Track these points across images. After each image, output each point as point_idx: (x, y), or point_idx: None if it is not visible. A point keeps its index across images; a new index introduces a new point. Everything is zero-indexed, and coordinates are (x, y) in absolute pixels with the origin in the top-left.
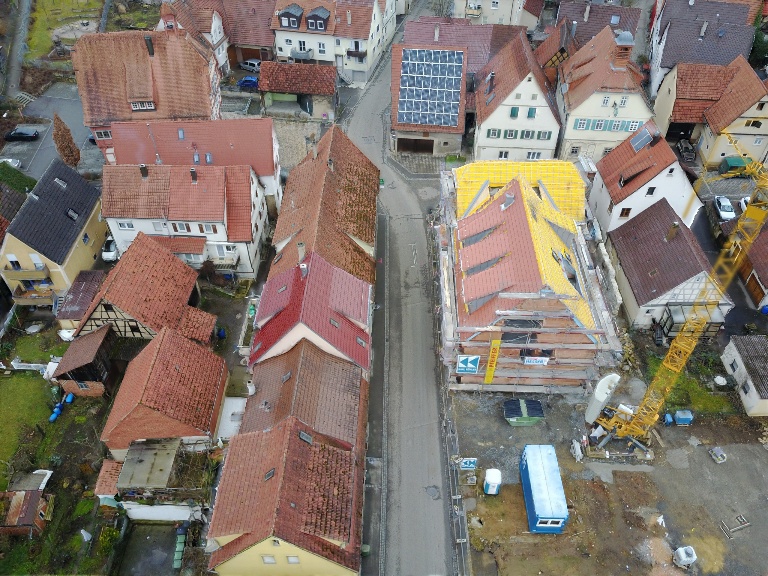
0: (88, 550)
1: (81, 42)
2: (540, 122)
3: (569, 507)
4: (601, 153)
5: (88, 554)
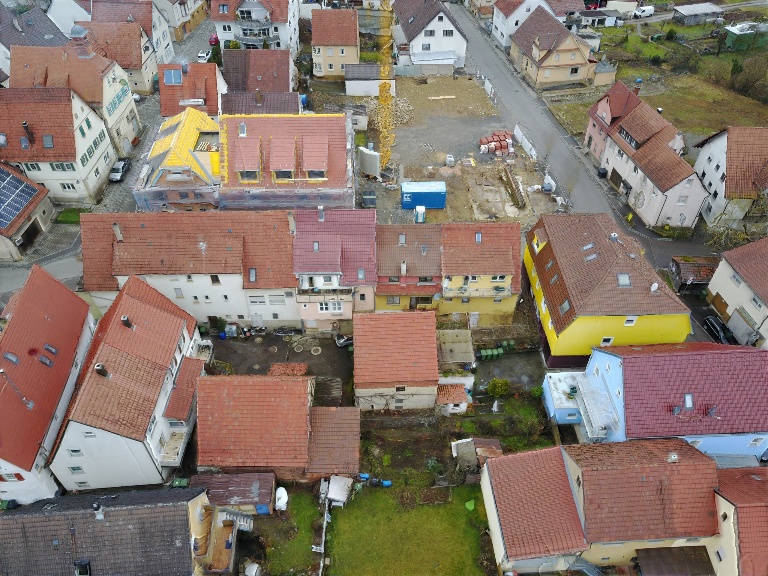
0: (500, 414)
1: None
2: (95, 127)
3: None
4: (127, 123)
5: (503, 413)
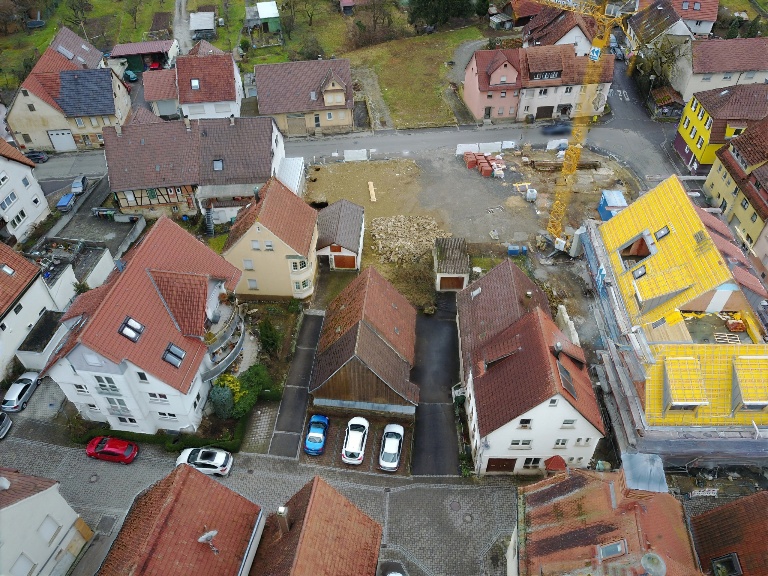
0: None
1: None
2: None
3: (593, 219)
4: None
5: None
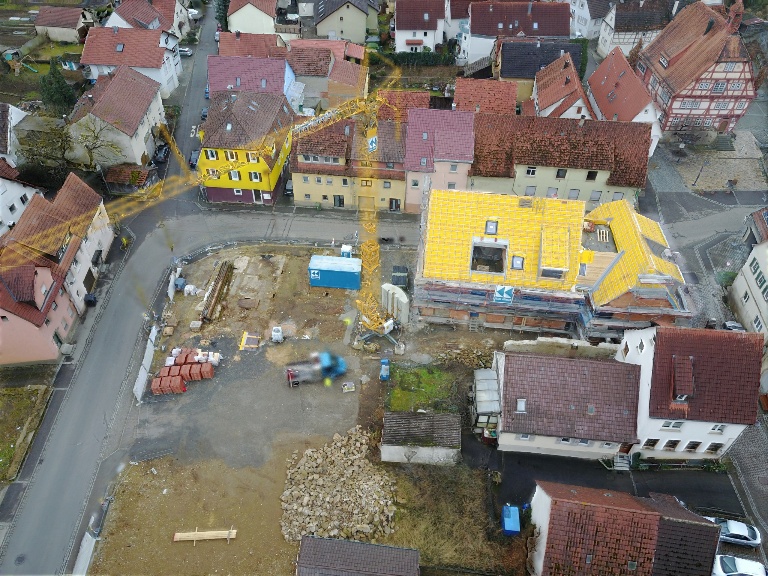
0: None
1: (693, 4)
2: None
3: (327, 294)
4: None
5: None
